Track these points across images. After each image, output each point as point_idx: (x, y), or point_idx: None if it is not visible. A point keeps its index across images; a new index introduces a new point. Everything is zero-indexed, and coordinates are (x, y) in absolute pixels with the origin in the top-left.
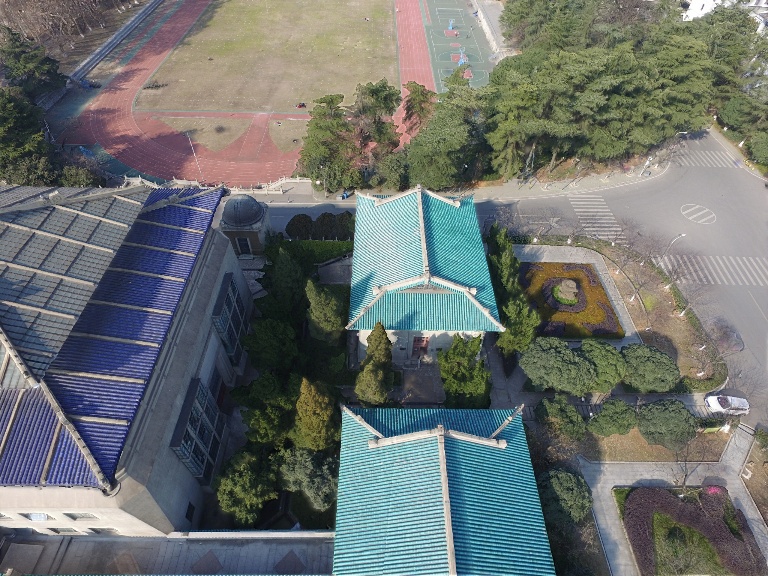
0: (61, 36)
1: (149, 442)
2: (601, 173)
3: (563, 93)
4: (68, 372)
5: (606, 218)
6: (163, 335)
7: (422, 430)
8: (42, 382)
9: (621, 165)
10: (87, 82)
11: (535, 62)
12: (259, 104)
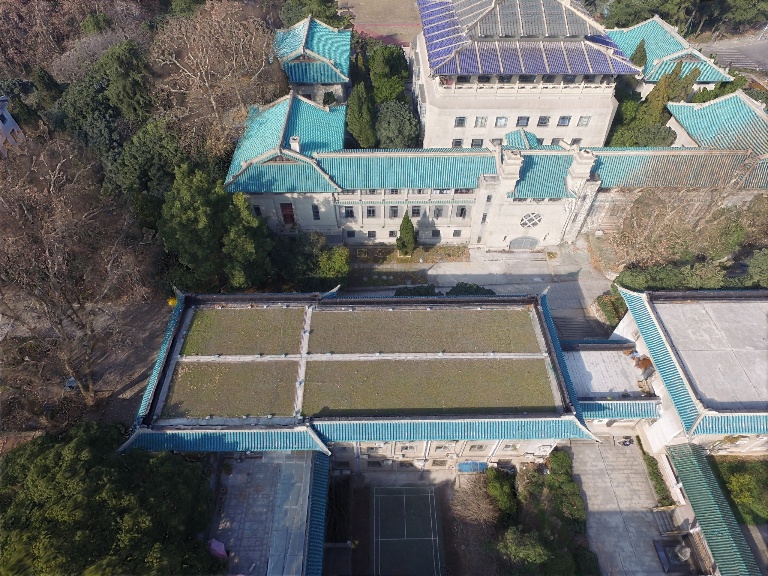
0: None
1: None
2: (731, 38)
3: None
4: (594, 42)
5: (745, 60)
6: None
7: None
8: None
9: (743, 34)
10: None
11: None
12: None
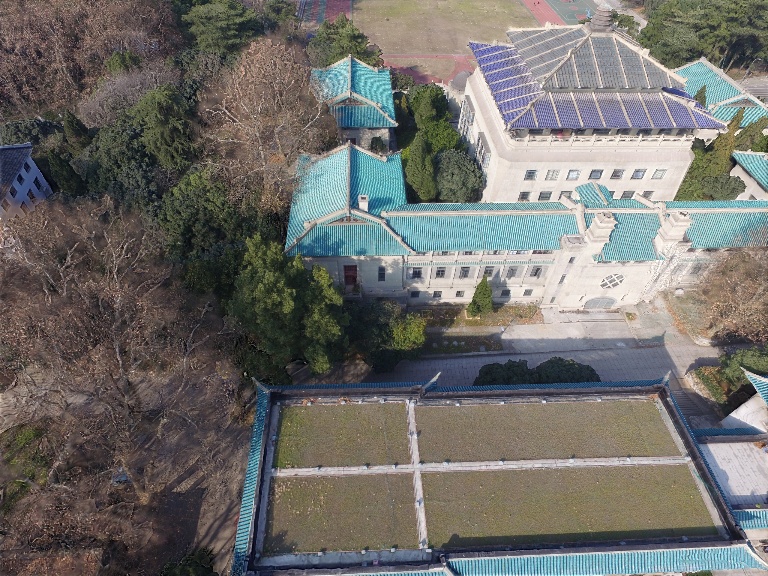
0: (249, 5)
1: None
2: (760, 76)
3: (763, 8)
4: None
5: None
6: None
7: None
8: (669, 94)
9: None
10: (309, 35)
11: (694, 4)
12: (451, 49)
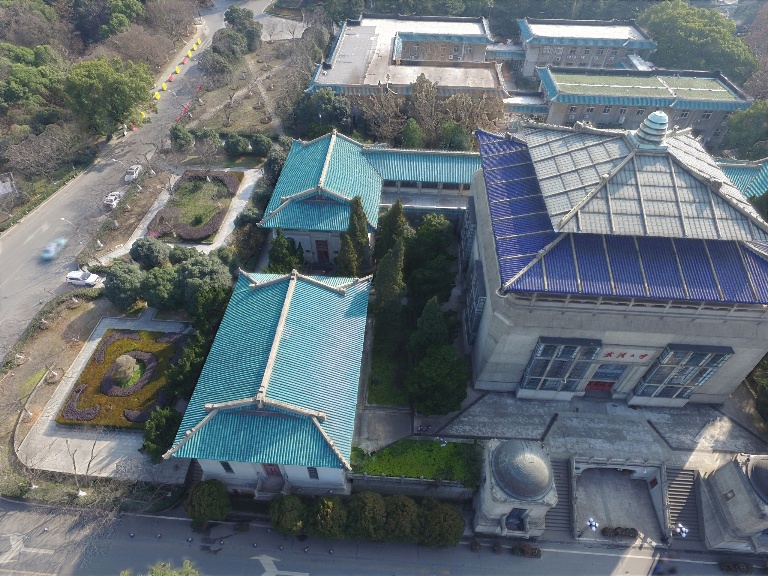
0: None
1: (480, 181)
2: None
3: None
4: None
5: None
6: (486, 175)
7: (328, 209)
8: None
9: None
10: None
11: None
12: None
